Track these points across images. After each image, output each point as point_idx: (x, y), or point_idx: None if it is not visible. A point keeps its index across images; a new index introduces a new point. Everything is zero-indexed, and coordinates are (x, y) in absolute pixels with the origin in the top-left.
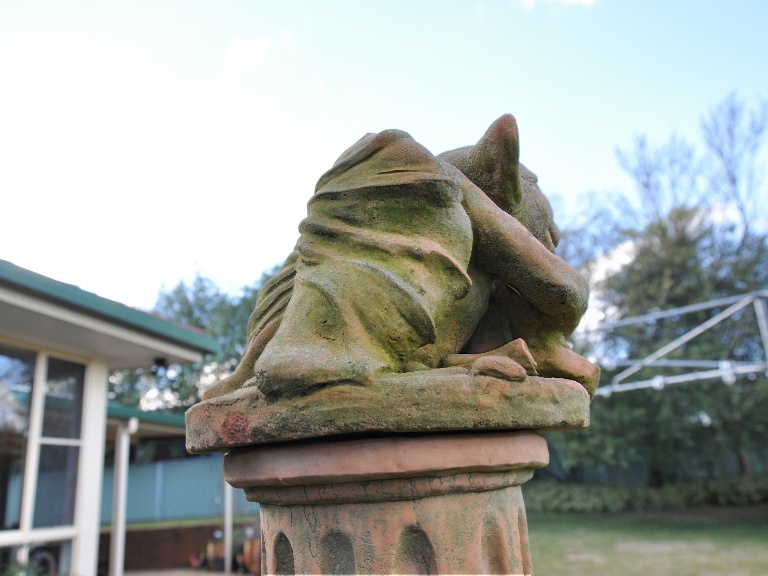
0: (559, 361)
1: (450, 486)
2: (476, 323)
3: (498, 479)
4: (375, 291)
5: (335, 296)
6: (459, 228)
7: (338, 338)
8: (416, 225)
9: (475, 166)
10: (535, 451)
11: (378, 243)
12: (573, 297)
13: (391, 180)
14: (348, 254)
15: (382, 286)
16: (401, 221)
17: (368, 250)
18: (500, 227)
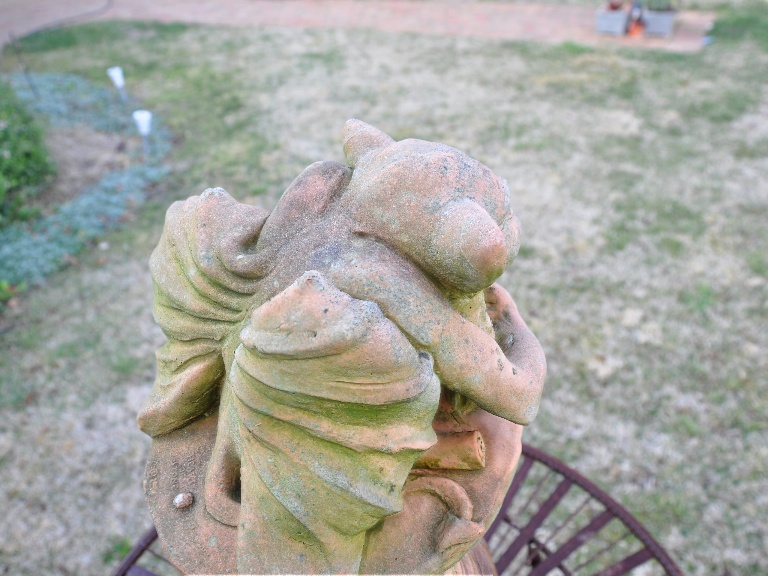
0: None
1: None
2: None
3: None
4: (347, 509)
5: (308, 525)
6: (429, 404)
7: (315, 546)
8: (382, 418)
9: (443, 266)
10: None
11: (341, 443)
12: None
13: (354, 397)
14: (305, 441)
15: (354, 504)
16: (365, 417)
17: (329, 443)
18: (472, 384)
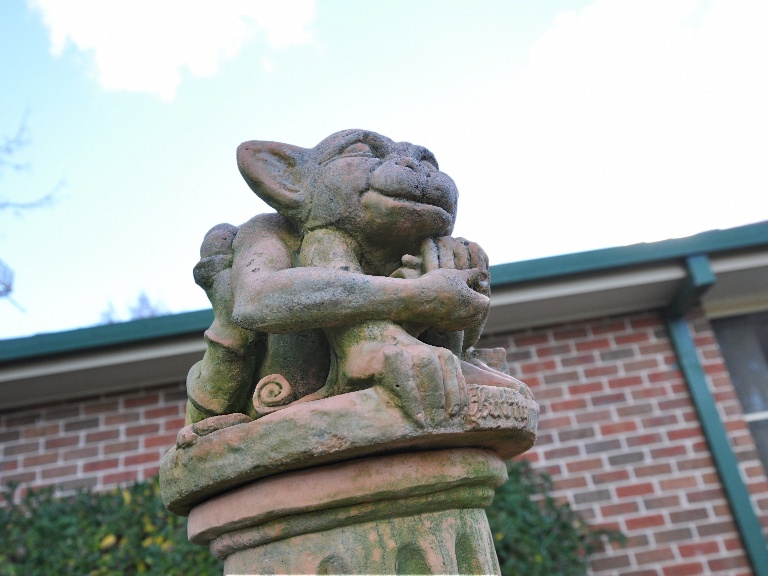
0: (348, 367)
1: (223, 546)
2: (305, 356)
3: (253, 534)
4: None
5: None
6: None
7: None
8: None
9: None
10: (272, 499)
11: None
12: (249, 321)
13: None
14: None
15: None
16: None
17: None
18: None
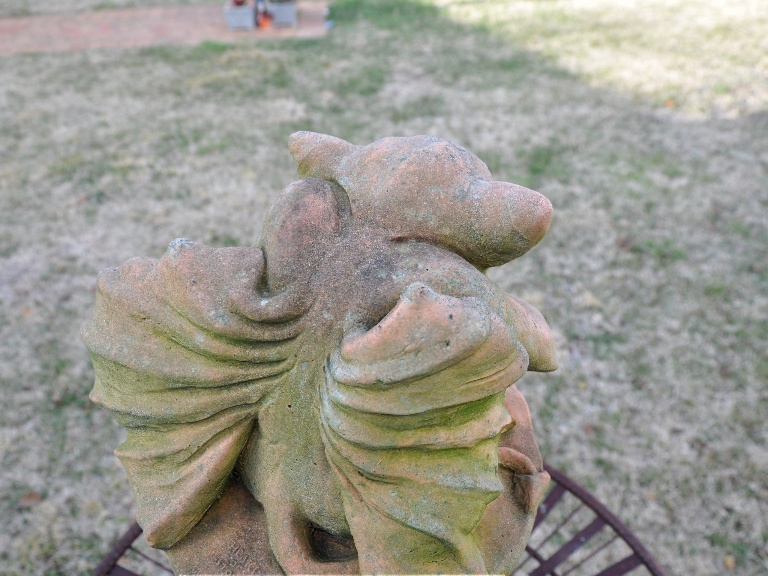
0: None
1: None
2: None
3: None
4: None
5: (450, 538)
6: None
7: (448, 559)
8: None
9: None
10: None
11: (458, 445)
12: None
13: (484, 392)
14: (421, 459)
15: None
16: None
17: (444, 451)
18: (529, 347)
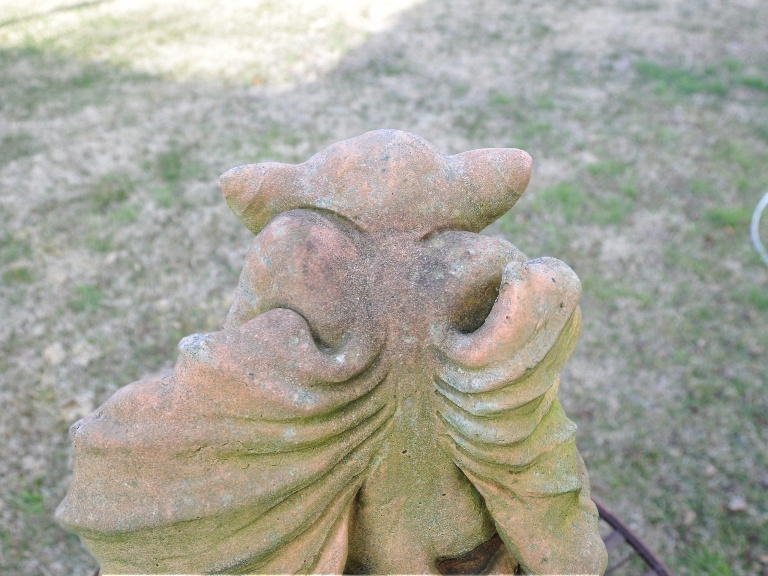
0: None
1: None
2: None
3: None
4: None
5: None
6: None
7: None
8: None
9: None
10: None
11: None
12: None
13: None
14: None
15: None
16: None
17: None
18: None
